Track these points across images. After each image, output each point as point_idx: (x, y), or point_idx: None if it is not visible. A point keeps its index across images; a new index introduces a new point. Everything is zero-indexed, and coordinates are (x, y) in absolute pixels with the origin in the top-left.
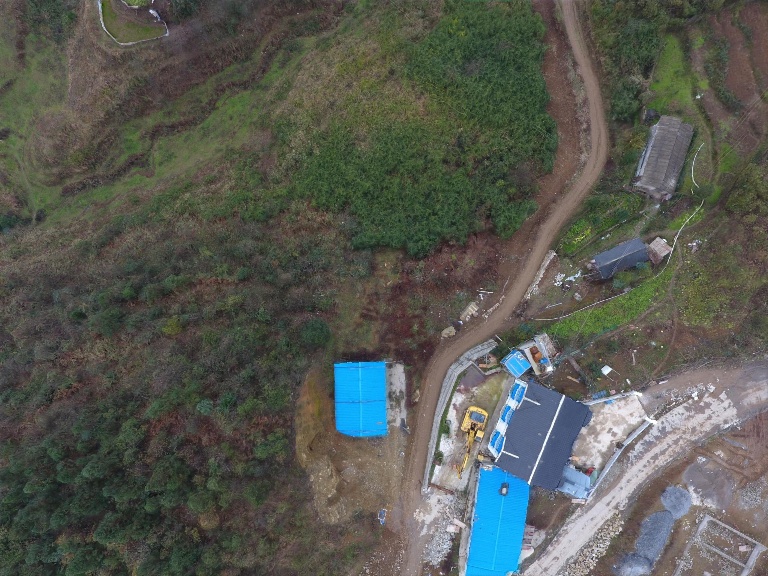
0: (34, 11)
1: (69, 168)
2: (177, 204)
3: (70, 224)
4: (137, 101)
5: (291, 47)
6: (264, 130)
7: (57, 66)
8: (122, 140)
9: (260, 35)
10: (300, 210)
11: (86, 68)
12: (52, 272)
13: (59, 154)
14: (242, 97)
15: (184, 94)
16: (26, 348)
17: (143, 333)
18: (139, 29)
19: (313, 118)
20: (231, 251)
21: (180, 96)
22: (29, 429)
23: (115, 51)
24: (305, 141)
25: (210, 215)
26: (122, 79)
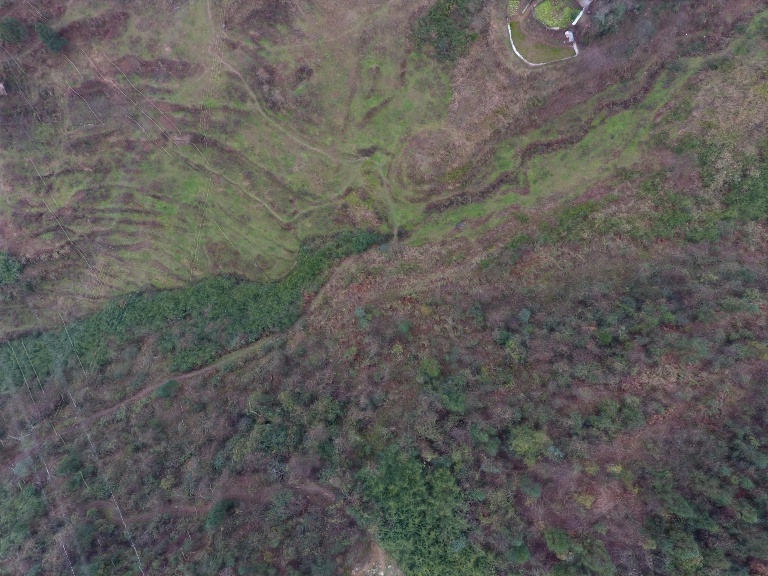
0: (423, 30)
1: (443, 185)
2: (597, 224)
3: (444, 241)
4: (525, 120)
5: (677, 67)
6: (662, 150)
7: (435, 84)
8: (497, 158)
9: (649, 55)
10: (756, 232)
11: (483, 87)
12: (470, 290)
13: (435, 171)
14: (623, 116)
15: (564, 113)
16: (569, 371)
17: (721, 359)
18: (547, 50)
19: (738, 140)
20: (732, 275)
21: (560, 115)
22: (624, 453)
23: (524, 71)
24: (735, 163)
25: (651, 236)
26: (519, 99)
